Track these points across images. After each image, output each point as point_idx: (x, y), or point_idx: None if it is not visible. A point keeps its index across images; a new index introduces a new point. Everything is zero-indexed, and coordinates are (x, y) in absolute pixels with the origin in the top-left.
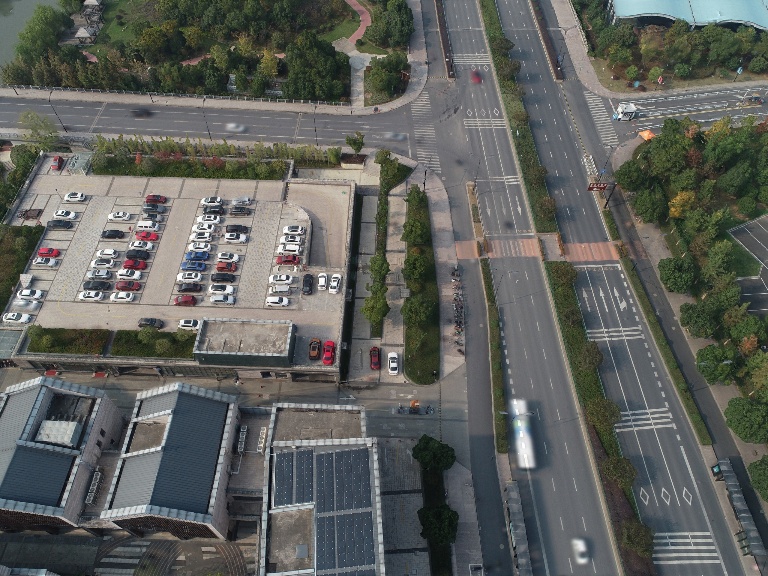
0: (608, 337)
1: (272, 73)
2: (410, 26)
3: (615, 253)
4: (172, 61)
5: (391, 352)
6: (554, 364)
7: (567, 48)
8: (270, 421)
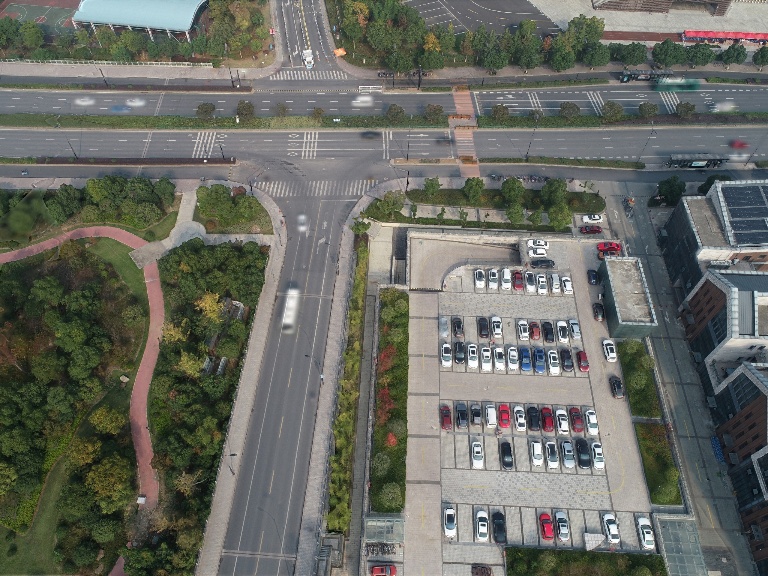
0: (539, 108)
1: (219, 311)
2: (146, 180)
3: (463, 92)
4: (172, 438)
5: (583, 220)
6: (568, 136)
7: (202, 79)
8: (715, 249)
